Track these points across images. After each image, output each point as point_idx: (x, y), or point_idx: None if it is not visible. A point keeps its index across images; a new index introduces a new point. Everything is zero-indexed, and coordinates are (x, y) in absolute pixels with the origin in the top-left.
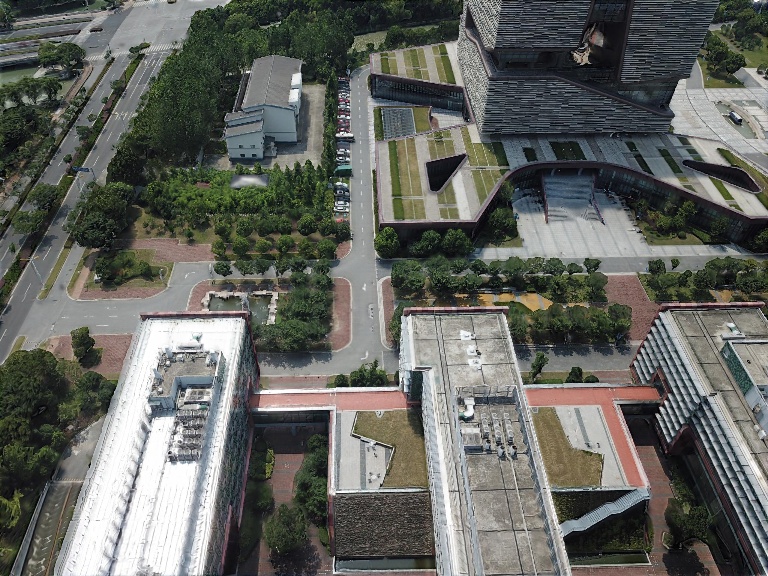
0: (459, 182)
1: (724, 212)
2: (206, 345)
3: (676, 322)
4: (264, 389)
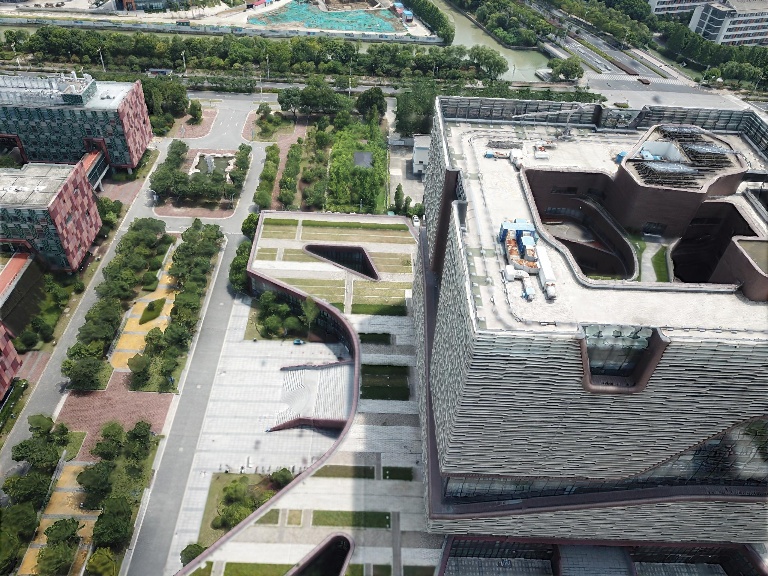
0: (322, 268)
1: None
2: (102, 100)
3: None
4: (134, 179)
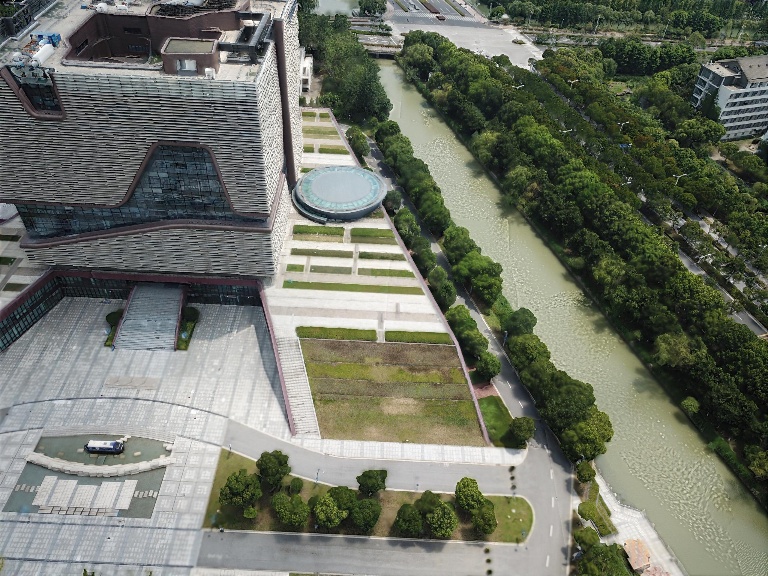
0: None
1: None
2: None
3: None
4: None
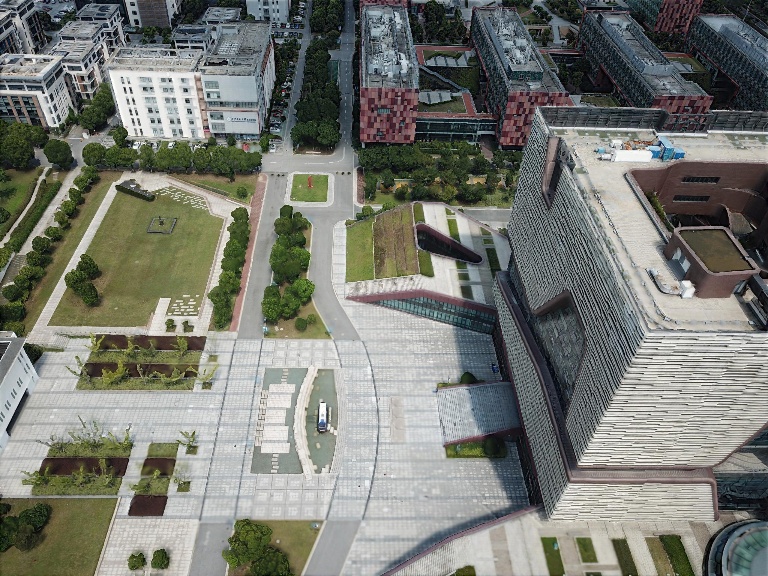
0: None
1: None
2: None
3: (561, 90)
4: None
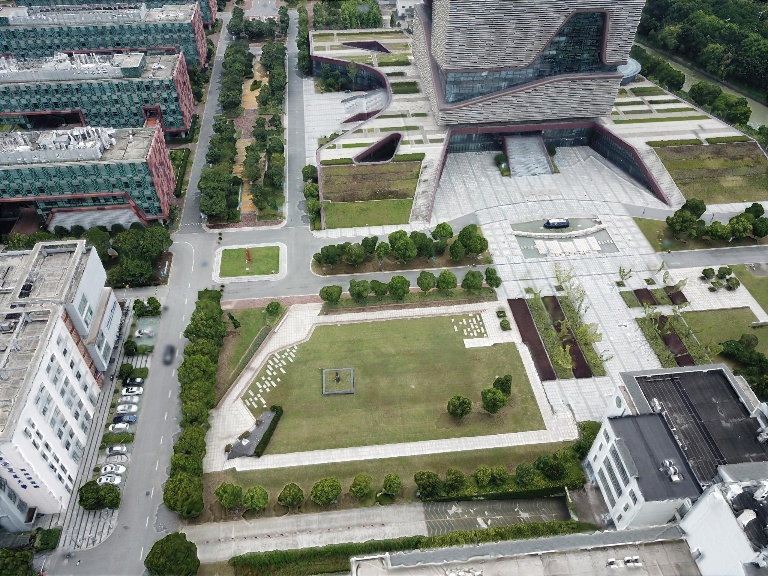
0: (355, 51)
1: None
2: None
3: (171, 55)
4: (213, 33)
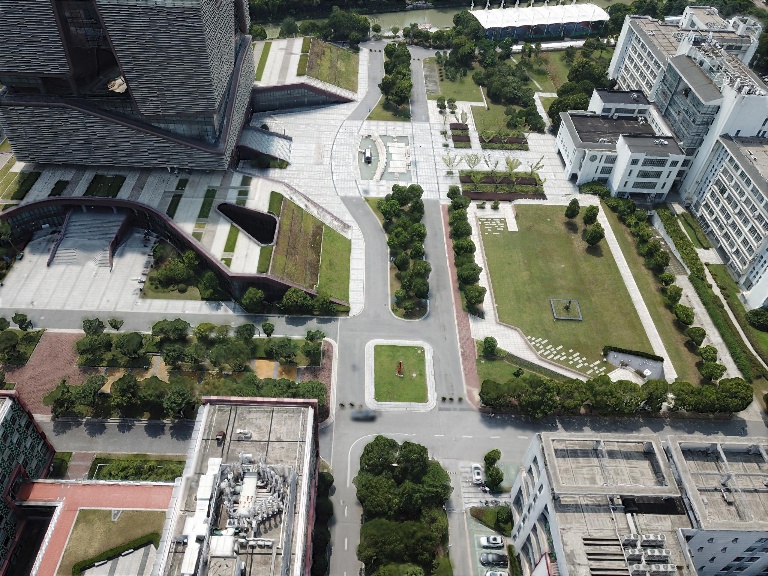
0: None
1: (215, 266)
2: None
3: None
4: None
